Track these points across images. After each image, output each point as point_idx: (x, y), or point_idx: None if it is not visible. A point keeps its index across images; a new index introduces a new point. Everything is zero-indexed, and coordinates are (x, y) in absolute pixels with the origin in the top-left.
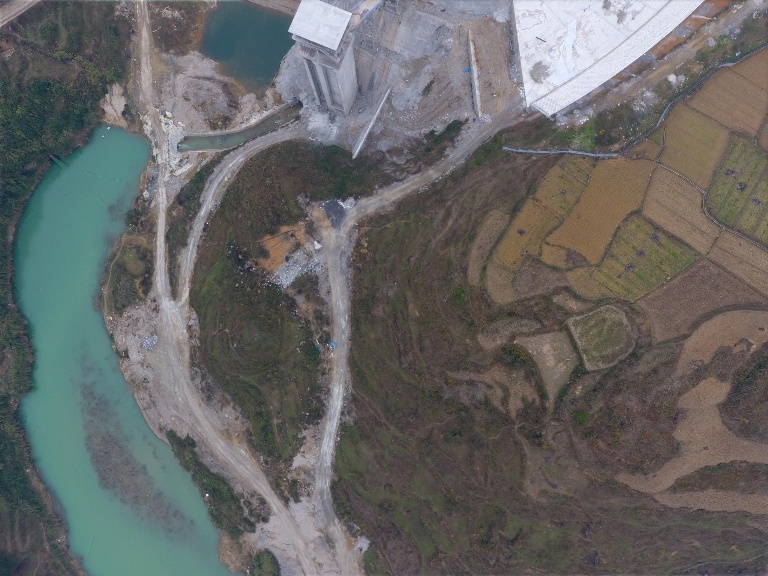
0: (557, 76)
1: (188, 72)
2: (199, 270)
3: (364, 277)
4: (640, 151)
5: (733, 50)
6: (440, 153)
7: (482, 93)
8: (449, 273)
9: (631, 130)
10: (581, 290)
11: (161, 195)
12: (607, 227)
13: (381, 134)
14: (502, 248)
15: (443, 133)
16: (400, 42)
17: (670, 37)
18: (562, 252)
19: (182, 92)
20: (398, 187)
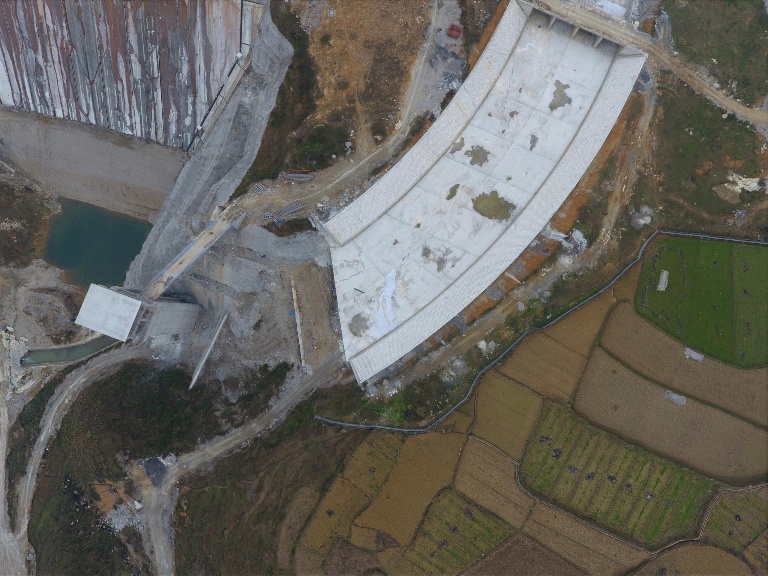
0: (376, 328)
1: (30, 284)
2: (36, 503)
3: (182, 544)
4: (449, 425)
5: (544, 313)
6: (265, 402)
7: (305, 341)
8: (259, 553)
9: (440, 403)
10: (393, 571)
11: (3, 415)
12: (417, 506)
13: (219, 360)
14: (310, 531)
15: (273, 372)
16: (228, 278)
17: (483, 296)
18: (372, 533)
19: (23, 307)
20: (220, 442)
